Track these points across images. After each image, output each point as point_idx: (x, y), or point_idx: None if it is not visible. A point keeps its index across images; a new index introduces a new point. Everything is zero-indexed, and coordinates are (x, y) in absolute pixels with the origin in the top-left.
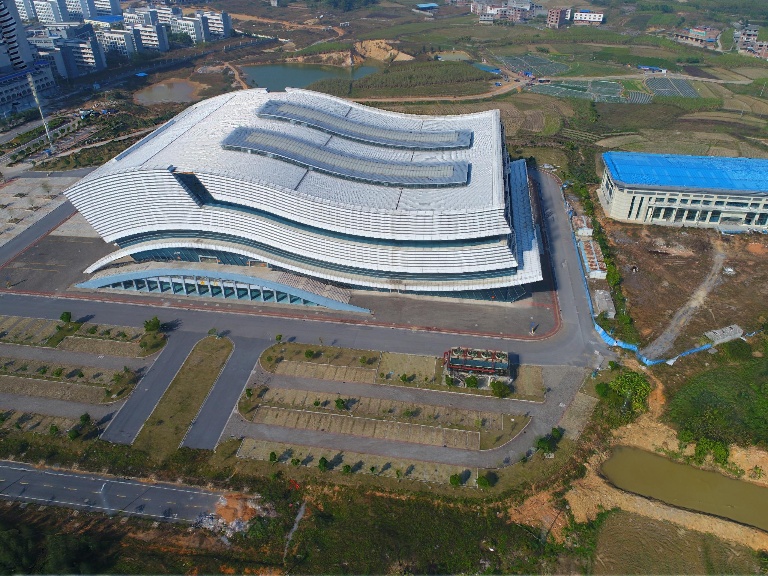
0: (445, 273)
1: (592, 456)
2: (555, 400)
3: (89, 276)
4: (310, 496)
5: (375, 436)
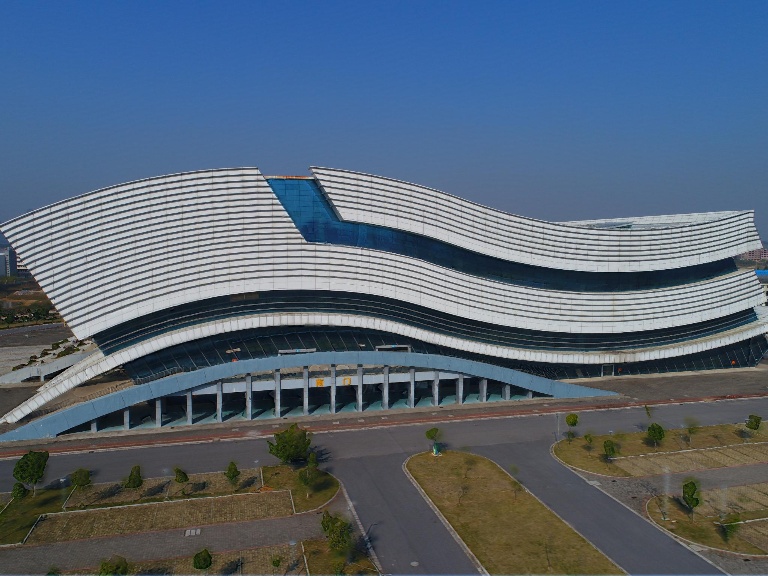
0: (677, 328)
1: None
2: None
3: (16, 426)
4: None
5: None
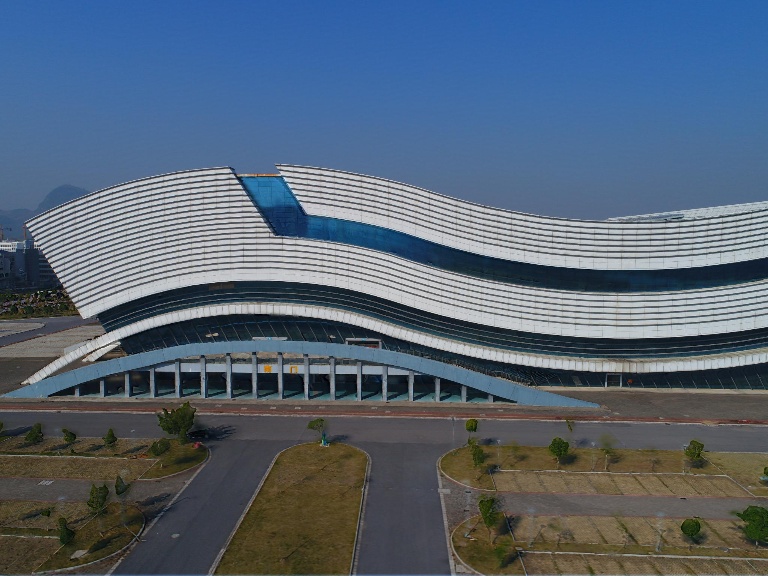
0: (708, 338)
1: None
2: None
3: None
4: None
5: None
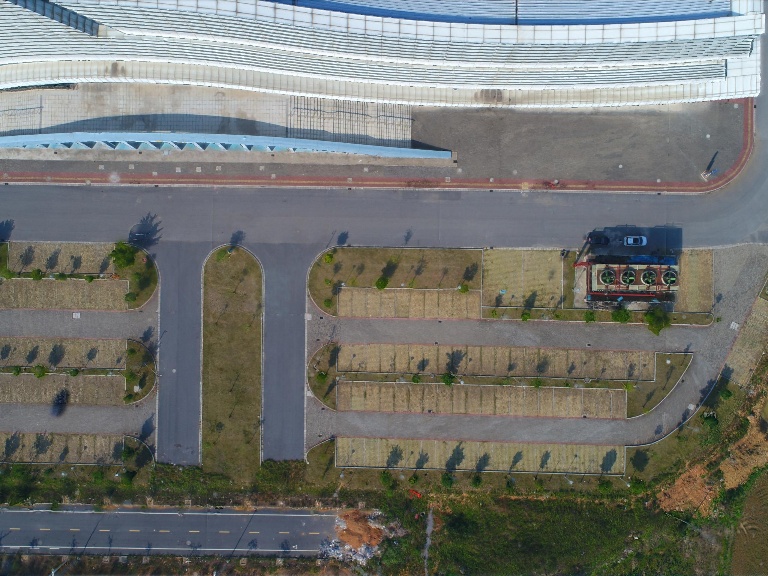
0: None
1: (759, 402)
2: (726, 318)
3: None
4: (435, 503)
5: (497, 413)
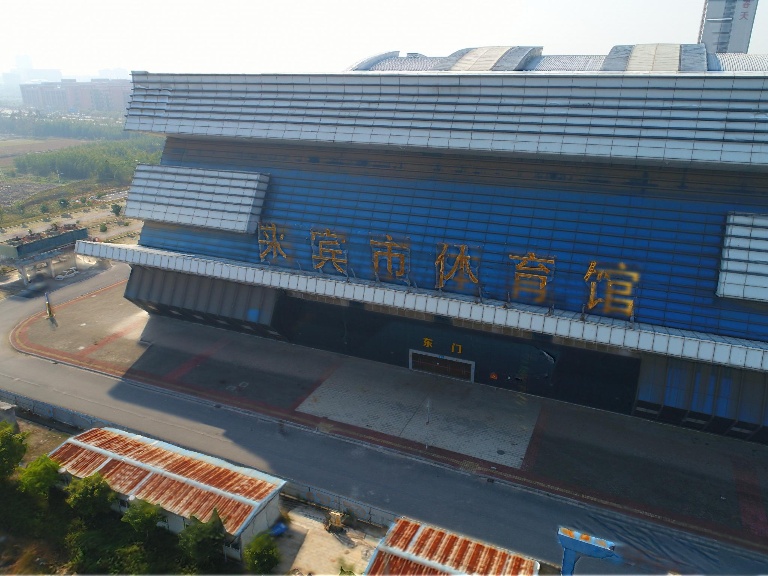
0: None
1: None
2: None
3: None
4: None
5: None
